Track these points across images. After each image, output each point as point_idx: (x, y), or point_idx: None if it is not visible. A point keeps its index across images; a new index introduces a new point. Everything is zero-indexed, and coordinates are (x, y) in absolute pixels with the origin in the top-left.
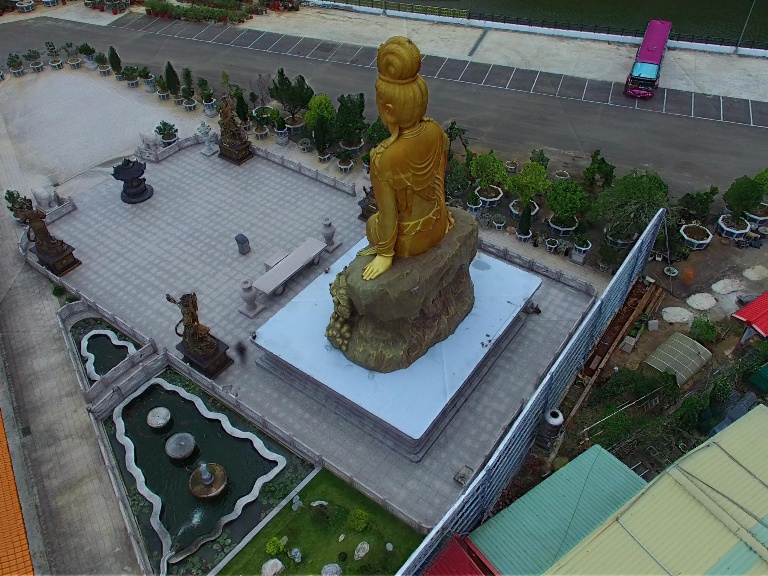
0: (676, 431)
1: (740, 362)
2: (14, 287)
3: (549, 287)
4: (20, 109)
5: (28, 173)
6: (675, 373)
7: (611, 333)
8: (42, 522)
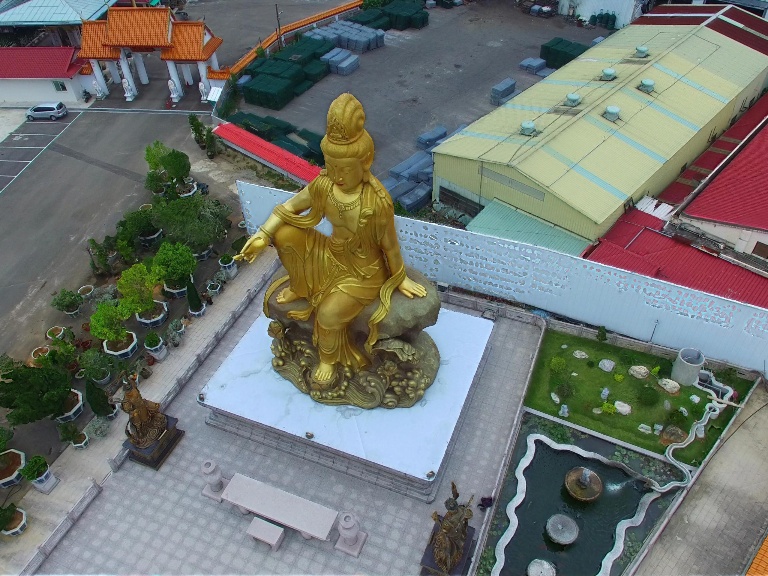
0: None
1: None
2: None
3: None
4: None
5: None
6: None
7: None
8: None
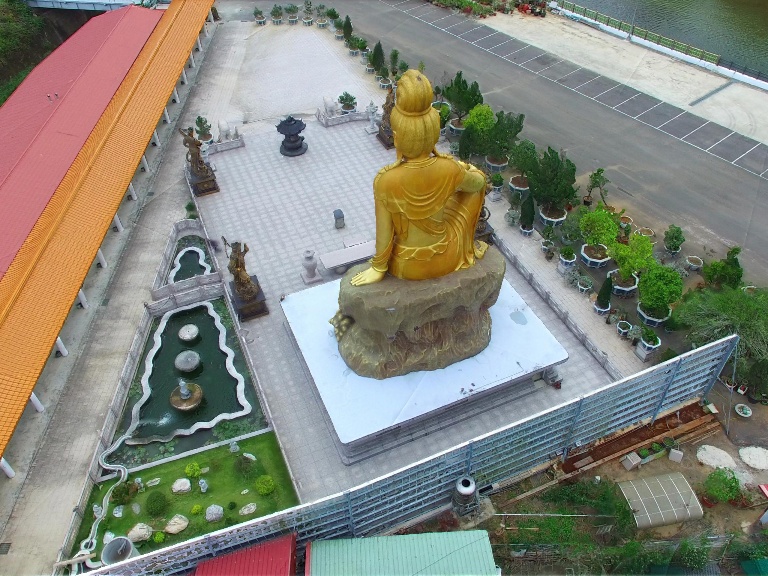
0: (614, 569)
1: (732, 538)
2: (166, 193)
3: (588, 368)
4: (260, 52)
5: (233, 106)
6: (638, 510)
7: (623, 442)
8: (73, 370)
